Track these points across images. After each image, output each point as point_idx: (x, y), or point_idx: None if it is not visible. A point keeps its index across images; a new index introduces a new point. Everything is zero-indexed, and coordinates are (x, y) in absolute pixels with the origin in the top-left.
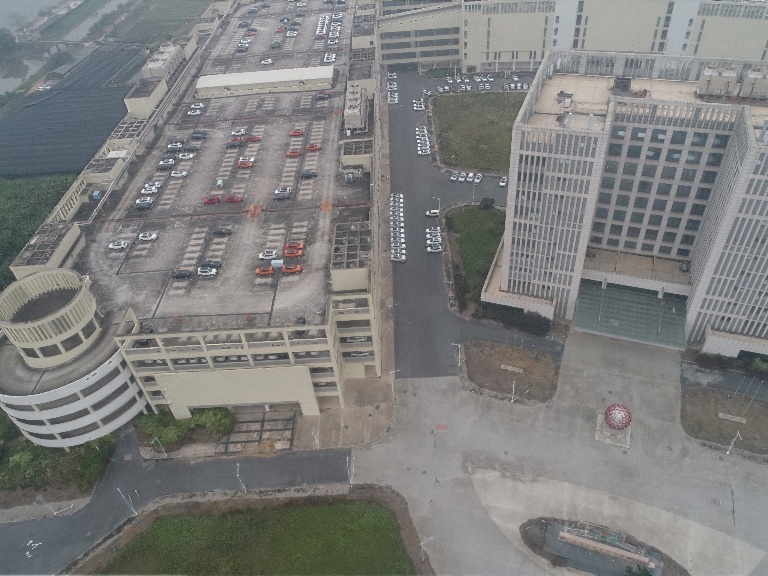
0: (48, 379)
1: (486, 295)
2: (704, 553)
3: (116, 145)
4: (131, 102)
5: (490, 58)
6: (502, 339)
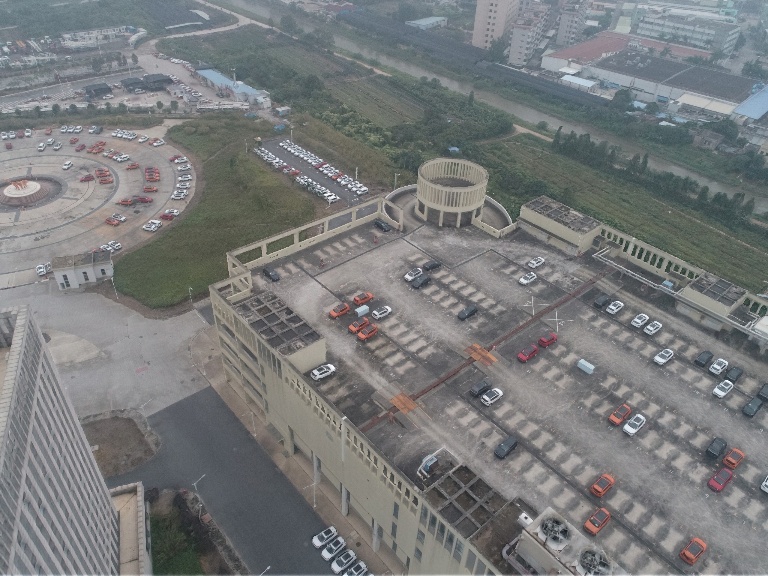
0: (414, 200)
1: (133, 484)
2: None
3: None
4: None
5: None
6: (107, 484)
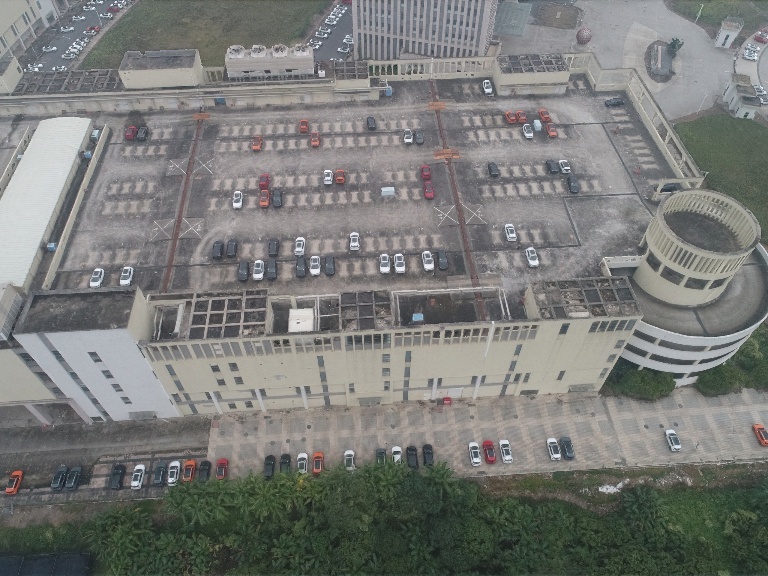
0: None
1: None
2: (644, 35)
3: (268, 332)
4: (131, 323)
5: (0, 49)
6: None
